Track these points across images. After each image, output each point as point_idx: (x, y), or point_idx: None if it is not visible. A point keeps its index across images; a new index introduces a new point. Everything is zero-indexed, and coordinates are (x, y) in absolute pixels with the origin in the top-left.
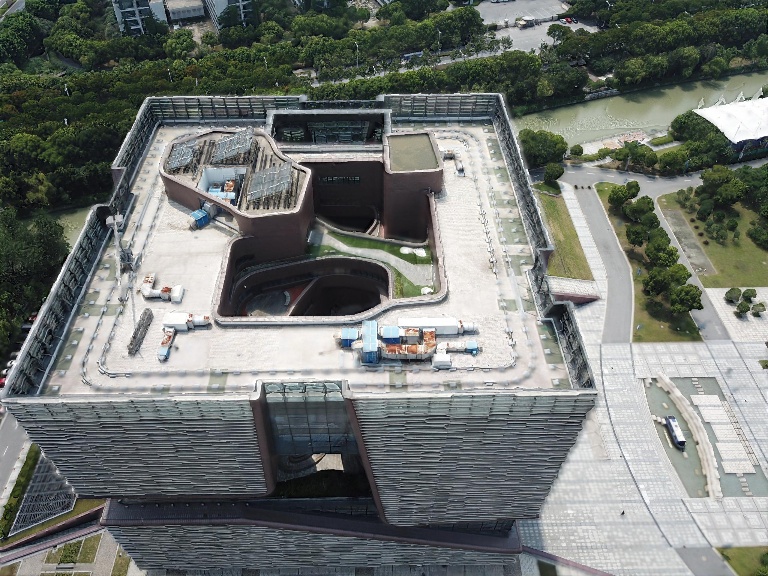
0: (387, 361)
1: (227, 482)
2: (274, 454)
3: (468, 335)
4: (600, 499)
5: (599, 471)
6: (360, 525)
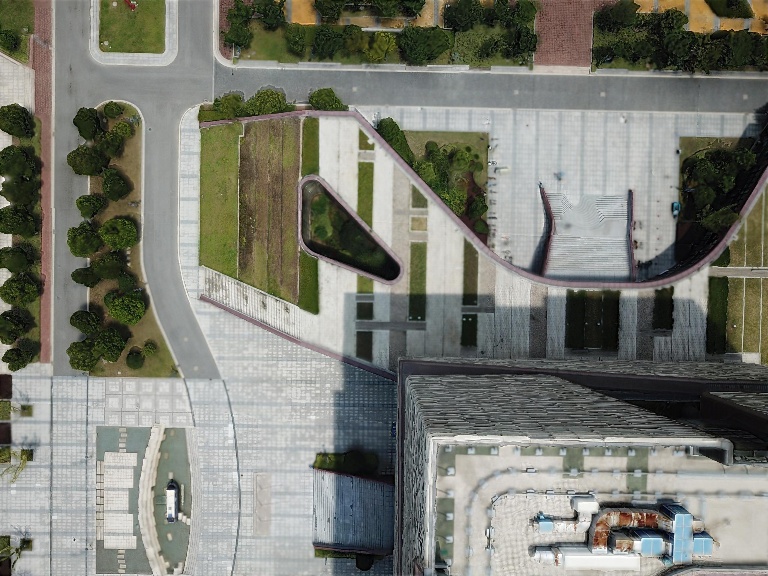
0: (651, 507)
1: (761, 399)
2: (731, 419)
3: (543, 546)
4: (279, 429)
5: (271, 460)
6: (573, 381)
